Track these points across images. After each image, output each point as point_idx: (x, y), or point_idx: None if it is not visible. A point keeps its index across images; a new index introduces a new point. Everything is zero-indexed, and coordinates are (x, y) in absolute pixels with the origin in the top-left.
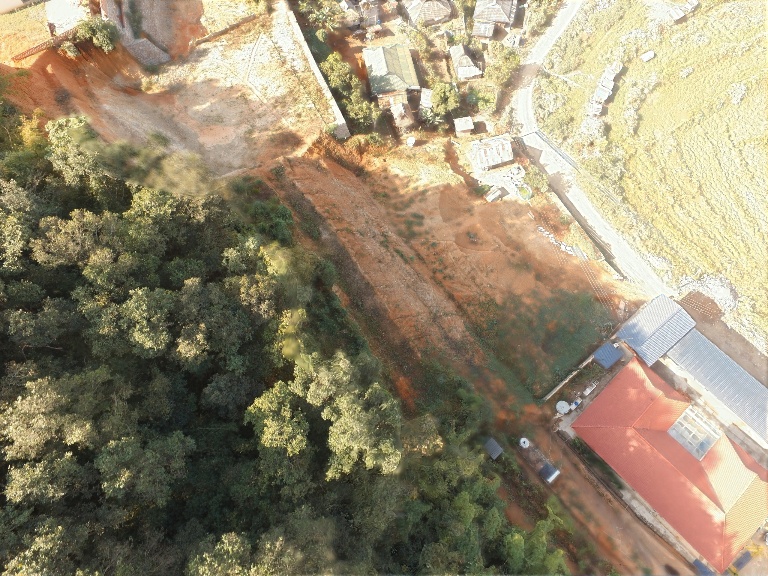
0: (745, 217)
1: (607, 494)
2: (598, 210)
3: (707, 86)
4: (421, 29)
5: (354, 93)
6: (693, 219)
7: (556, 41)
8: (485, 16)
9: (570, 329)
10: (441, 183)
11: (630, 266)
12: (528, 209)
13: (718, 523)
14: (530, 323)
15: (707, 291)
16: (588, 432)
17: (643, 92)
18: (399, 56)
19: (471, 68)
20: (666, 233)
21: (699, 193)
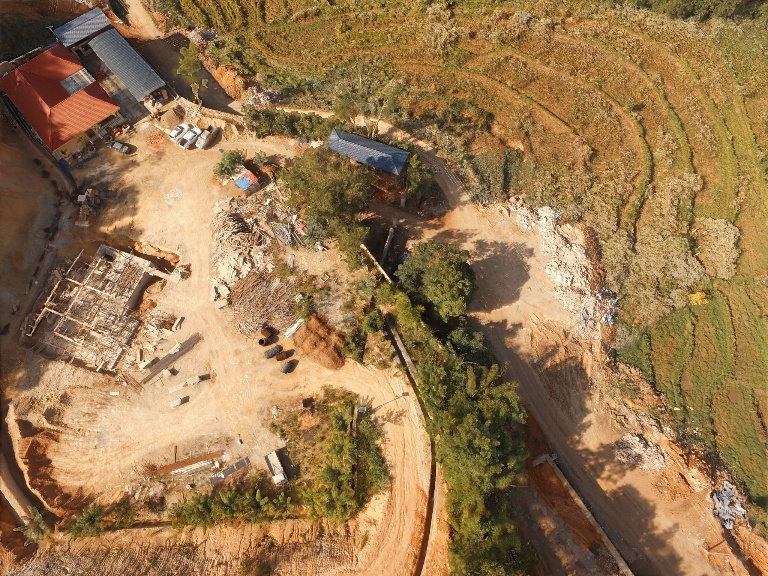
0: None
1: (16, 124)
2: None
3: None
4: None
5: None
6: None
7: None
8: None
9: (39, 37)
10: None
11: (137, 18)
12: None
13: (48, 117)
14: (4, 29)
15: (187, 33)
16: (2, 81)
17: None
18: None
19: None
20: (183, 2)
21: None
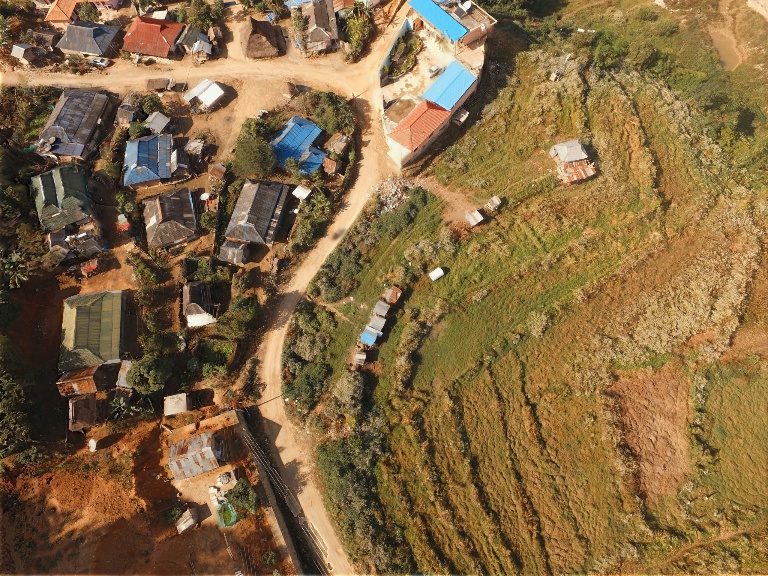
0: (524, 515)
1: None
2: (332, 522)
3: (504, 313)
4: (159, 254)
5: (0, 403)
6: (455, 525)
7: (326, 260)
8: (237, 235)
9: None
10: (106, 523)
11: None
12: (229, 541)
13: None
14: None
15: None
16: None
17: (426, 325)
18: (103, 313)
19: (203, 315)
20: (417, 550)
21: (471, 480)
